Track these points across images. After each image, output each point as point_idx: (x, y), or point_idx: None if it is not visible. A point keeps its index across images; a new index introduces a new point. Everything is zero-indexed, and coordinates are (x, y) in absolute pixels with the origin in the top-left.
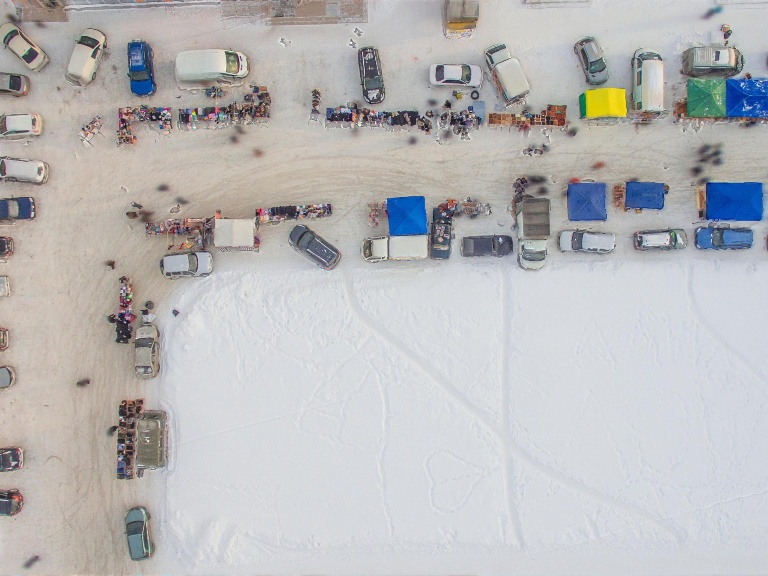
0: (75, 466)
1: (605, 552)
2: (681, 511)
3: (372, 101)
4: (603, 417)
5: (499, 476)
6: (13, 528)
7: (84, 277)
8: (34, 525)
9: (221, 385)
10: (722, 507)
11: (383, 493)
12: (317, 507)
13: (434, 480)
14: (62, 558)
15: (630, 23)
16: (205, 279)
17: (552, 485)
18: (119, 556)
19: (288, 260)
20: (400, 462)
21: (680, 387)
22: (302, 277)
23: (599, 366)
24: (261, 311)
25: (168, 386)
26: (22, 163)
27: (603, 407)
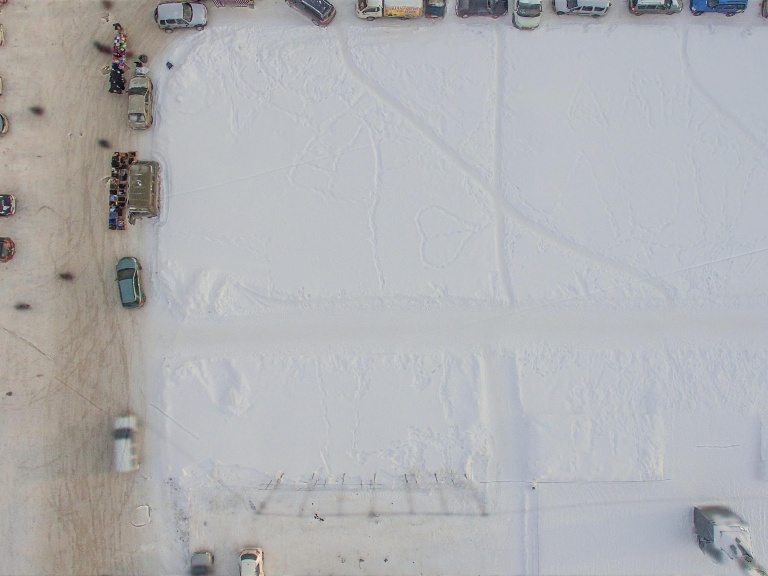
0: (67, 217)
1: (594, 309)
2: (670, 269)
3: None
4: (595, 177)
5: (490, 233)
6: (4, 277)
7: (78, 29)
8: (25, 274)
9: (214, 136)
10: (711, 267)
11: (374, 247)
12: (308, 259)
13: (425, 235)
14: (53, 307)
15: None
16: (199, 33)
17: (543, 243)
18: (110, 307)
19: (283, 17)
20: (392, 216)
21: (672, 149)
22: (297, 33)
23: (592, 127)
24: (255, 65)
25: (161, 138)
26: None
27: (595, 167)
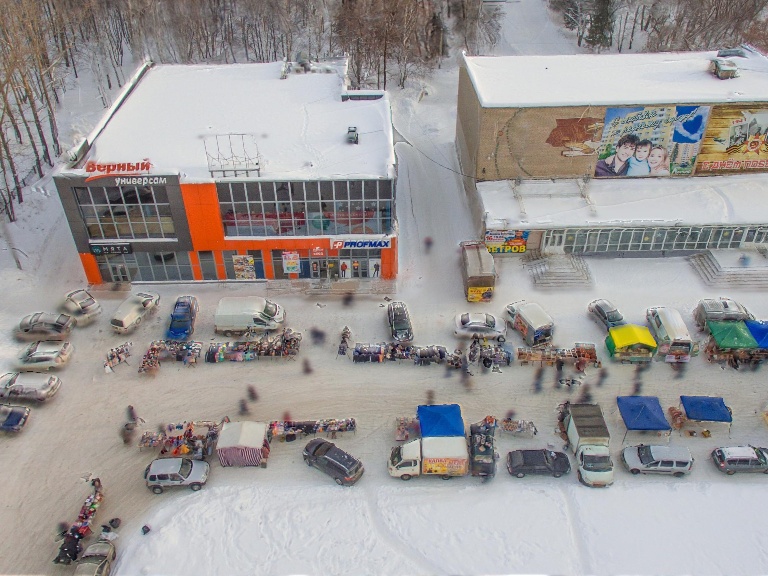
0: None
1: None
2: None
3: (401, 339)
4: None
5: None
6: None
7: (47, 490)
8: None
9: None
10: None
11: None
12: None
13: None
14: None
15: (634, 296)
16: (194, 493)
17: None
18: None
19: (299, 476)
20: None
21: None
22: (314, 494)
23: None
24: (257, 528)
25: None
26: (37, 373)
27: None
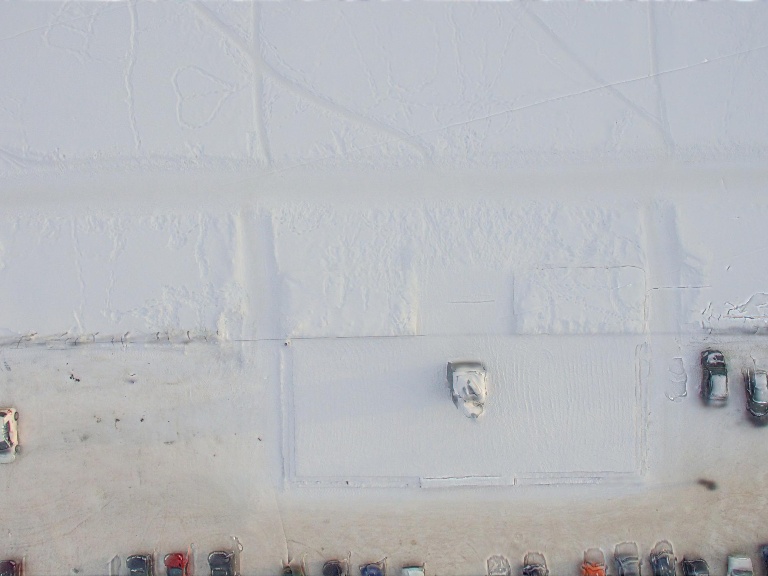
0: None
1: (352, 168)
2: (428, 128)
3: None
4: (354, 37)
5: (248, 93)
6: None
7: None
8: None
9: None
10: (469, 125)
11: (130, 108)
12: (63, 120)
13: (182, 95)
14: None
15: None
16: None
17: (301, 103)
18: None
19: None
20: (148, 77)
21: (432, 9)
22: None
23: None
24: None
25: None
26: None
27: (354, 28)
